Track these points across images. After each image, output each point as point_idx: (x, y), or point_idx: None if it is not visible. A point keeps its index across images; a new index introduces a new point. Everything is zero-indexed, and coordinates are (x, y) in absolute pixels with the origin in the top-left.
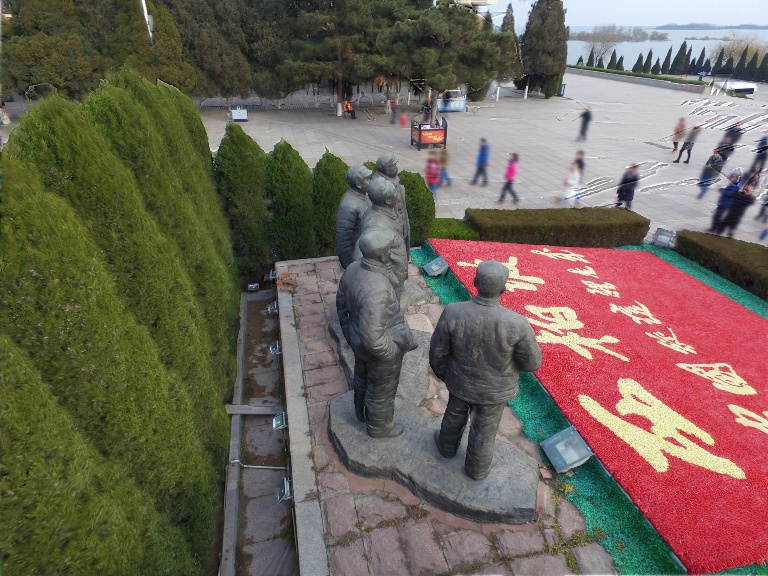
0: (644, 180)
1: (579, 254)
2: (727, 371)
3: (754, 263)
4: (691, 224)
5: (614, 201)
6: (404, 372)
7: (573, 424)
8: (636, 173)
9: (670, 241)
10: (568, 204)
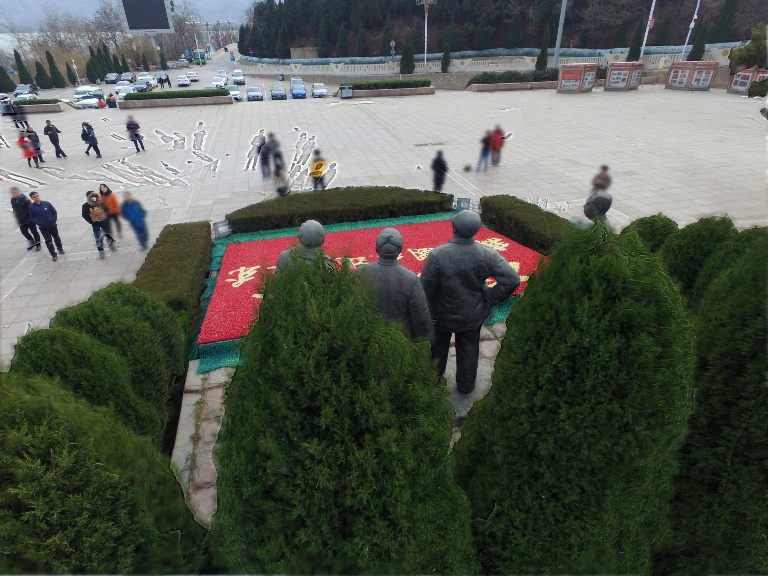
0: (62, 211)
1: (239, 268)
2: (416, 250)
3: (293, 209)
4: (182, 218)
5: (95, 236)
6: (478, 371)
7: (516, 294)
8: (36, 210)
9: (228, 228)
10: (73, 261)
